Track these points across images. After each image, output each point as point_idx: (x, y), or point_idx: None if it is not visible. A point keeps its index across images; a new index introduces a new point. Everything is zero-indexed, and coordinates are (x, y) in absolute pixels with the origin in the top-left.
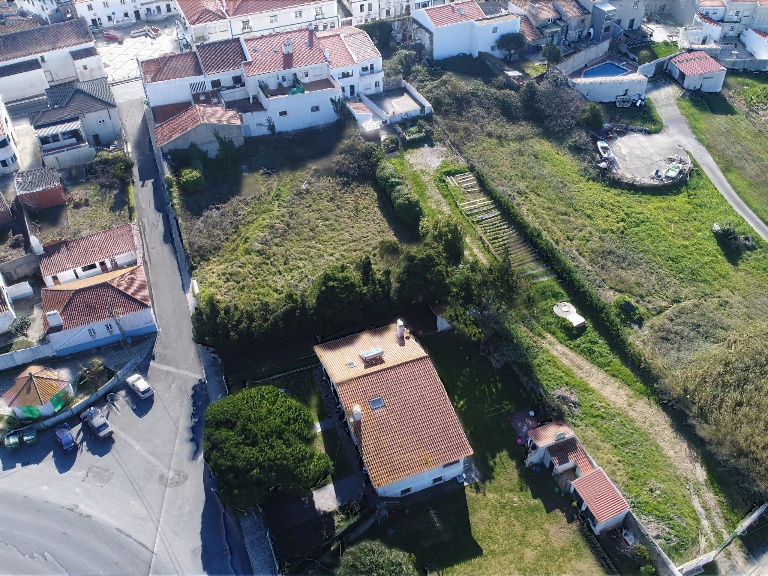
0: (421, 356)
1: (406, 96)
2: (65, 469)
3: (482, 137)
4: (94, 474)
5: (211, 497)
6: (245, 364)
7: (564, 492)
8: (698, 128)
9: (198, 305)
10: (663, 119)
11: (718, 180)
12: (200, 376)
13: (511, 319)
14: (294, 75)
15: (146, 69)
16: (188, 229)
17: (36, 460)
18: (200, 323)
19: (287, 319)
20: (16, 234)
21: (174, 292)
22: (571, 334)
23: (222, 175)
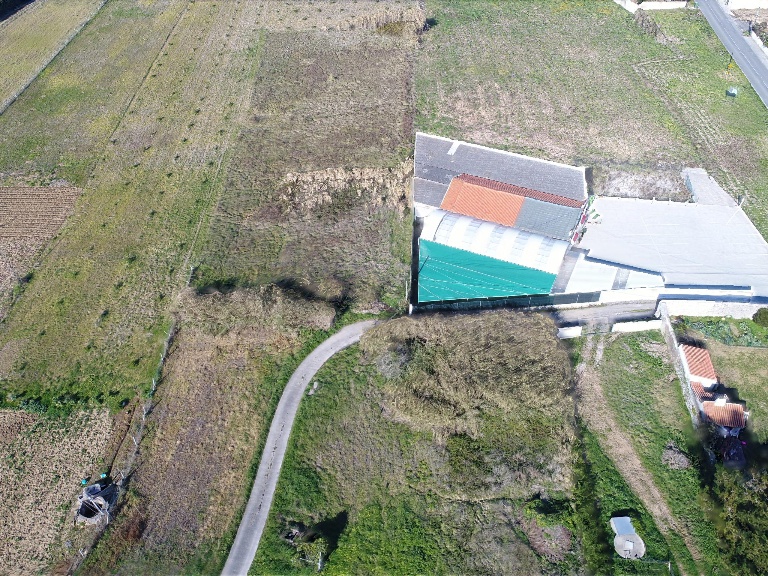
0: None
1: None
2: None
3: None
4: None
5: None
6: None
7: None
8: None
9: None
10: None
11: None
12: None
13: None
14: None
15: None
16: None
17: None
18: None
19: None
20: None
21: None
22: (638, 514)
23: None
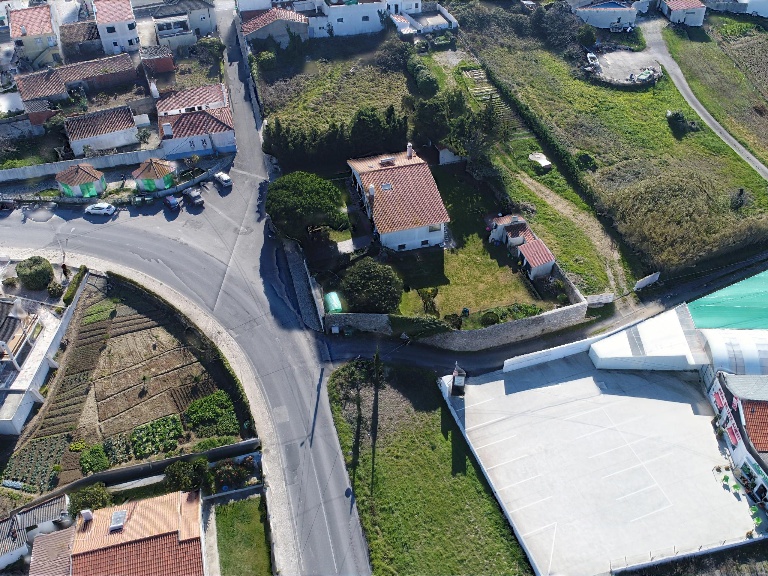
0: (421, 162)
1: (439, 16)
2: (171, 219)
3: (495, 46)
4: (191, 223)
5: (268, 241)
6: None
7: (514, 256)
8: (674, 49)
9: None
10: (647, 42)
11: (681, 85)
12: (265, 178)
13: (493, 152)
14: None
15: None
16: (263, 90)
17: (152, 213)
18: (268, 137)
19: (330, 142)
20: (139, 86)
21: (250, 130)
22: (539, 171)
23: (290, 61)
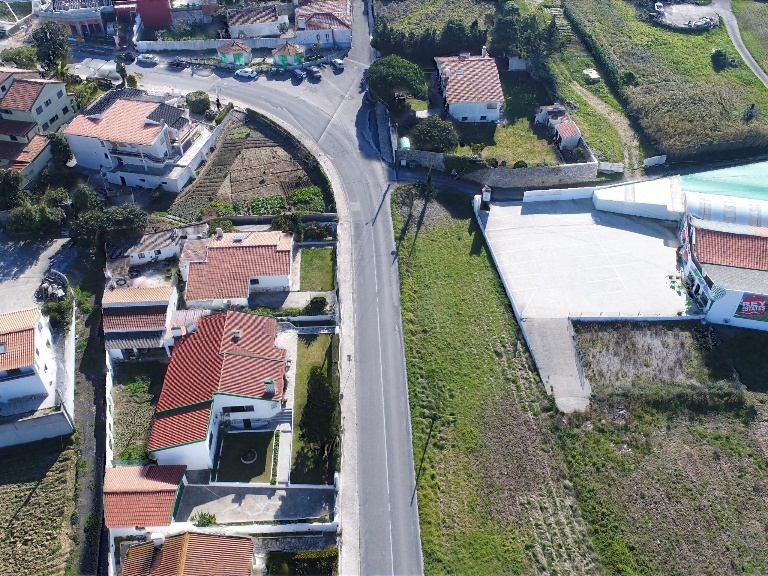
0: None
1: None
2: (296, 85)
3: None
4: (310, 89)
5: (365, 106)
6: None
7: (551, 134)
8: (737, 6)
9: None
10: None
11: (734, 33)
12: None
13: (551, 61)
14: None
15: None
16: (378, 7)
17: (283, 80)
18: (376, 34)
19: (423, 42)
20: None
21: (364, 34)
22: (589, 82)
23: None
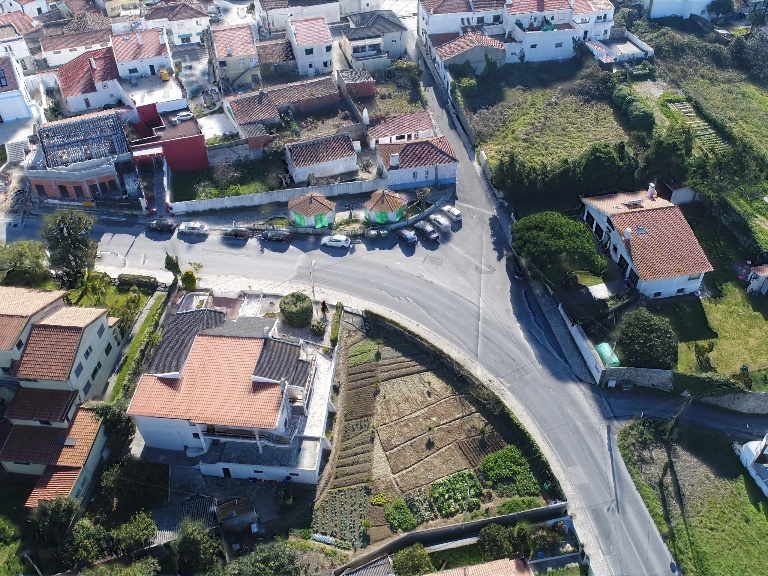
0: (672, 205)
1: (629, 43)
2: (409, 255)
3: (696, 78)
4: (430, 260)
5: (514, 282)
6: (525, 209)
7: None
8: None
9: (487, 167)
10: None
11: None
12: (493, 213)
13: (735, 195)
14: (544, 17)
15: (426, 5)
16: None
17: (388, 247)
18: (501, 172)
19: (562, 178)
20: (344, 111)
21: (463, 160)
22: None
23: (486, 88)
